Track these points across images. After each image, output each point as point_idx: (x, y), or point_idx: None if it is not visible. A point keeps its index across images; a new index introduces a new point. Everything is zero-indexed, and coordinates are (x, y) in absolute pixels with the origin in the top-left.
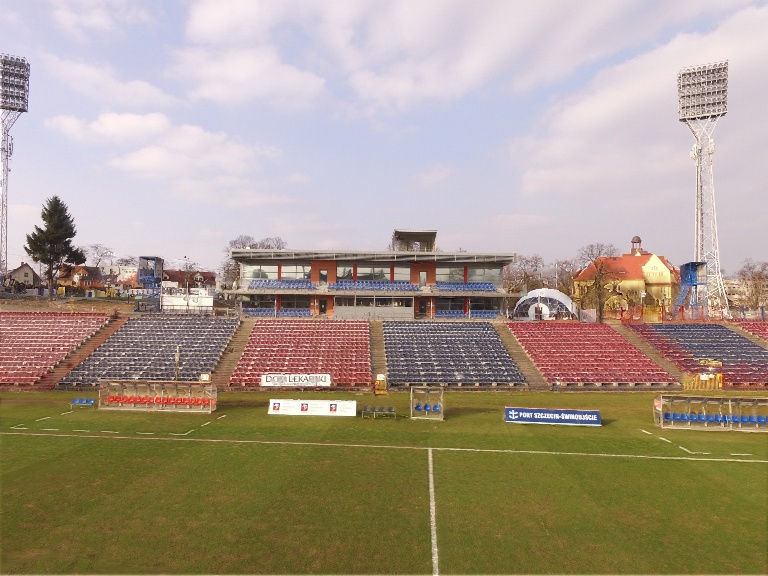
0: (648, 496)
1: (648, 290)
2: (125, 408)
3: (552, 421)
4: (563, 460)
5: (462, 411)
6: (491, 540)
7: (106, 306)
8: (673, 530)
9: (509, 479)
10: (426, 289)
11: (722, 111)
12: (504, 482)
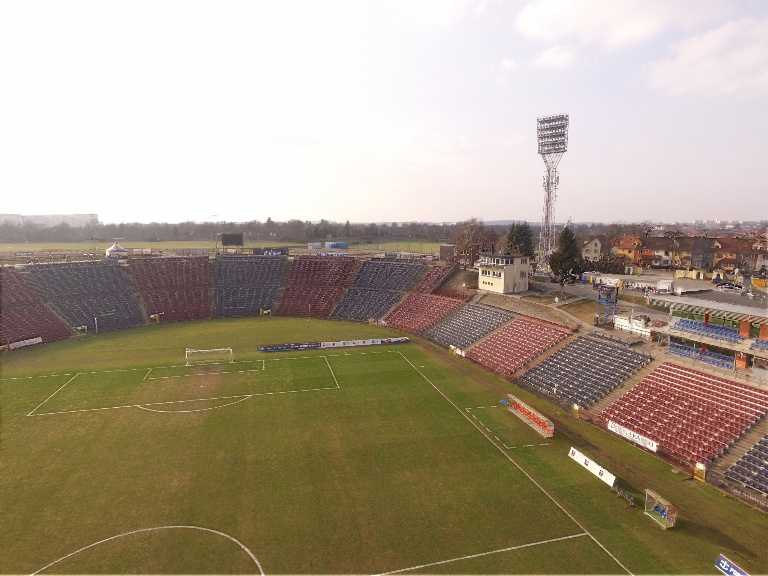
0: None
1: None
2: (517, 414)
3: None
4: None
5: (710, 535)
6: (495, 571)
7: (585, 314)
8: None
9: (574, 574)
10: None
11: None
12: (567, 572)
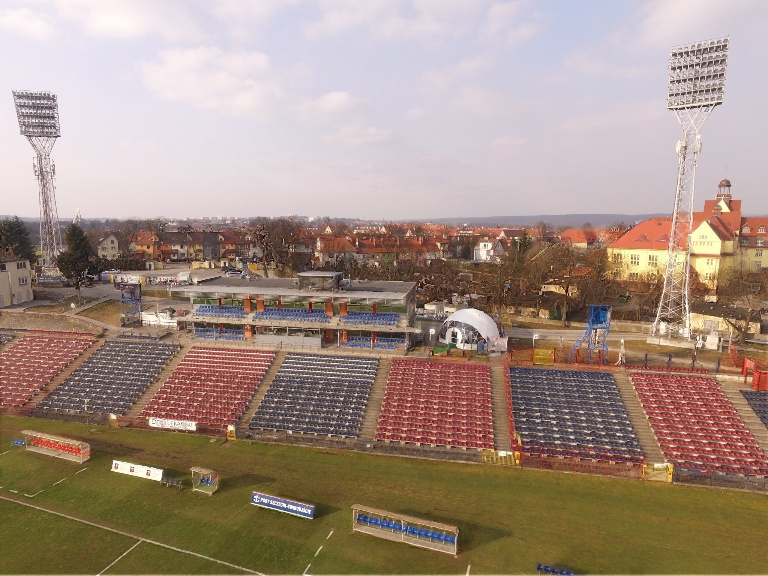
0: None
1: (691, 262)
2: (40, 450)
3: (281, 509)
4: (199, 571)
5: (244, 481)
6: None
7: (109, 316)
8: None
9: None
10: (334, 320)
11: (716, 100)
12: None
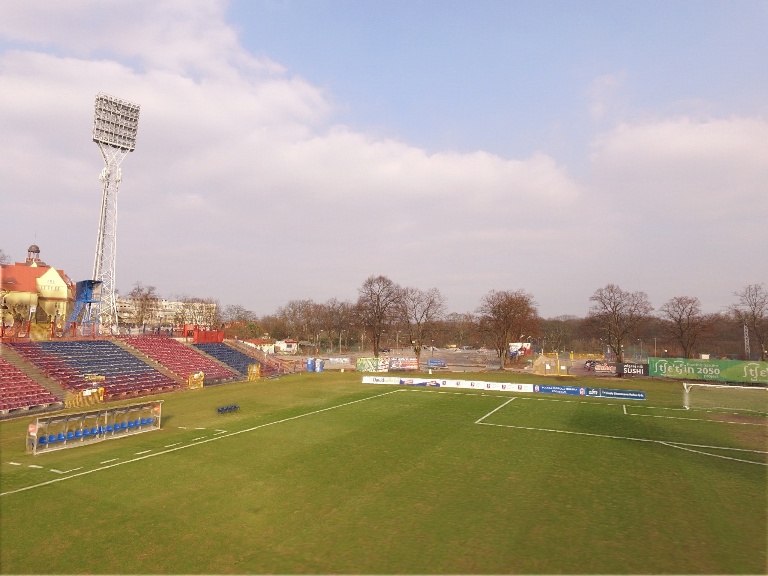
0: (4, 538)
1: (41, 304)
2: None
3: None
4: None
5: None
6: None
7: None
8: (28, 564)
9: None
10: None
11: (131, 147)
12: None
